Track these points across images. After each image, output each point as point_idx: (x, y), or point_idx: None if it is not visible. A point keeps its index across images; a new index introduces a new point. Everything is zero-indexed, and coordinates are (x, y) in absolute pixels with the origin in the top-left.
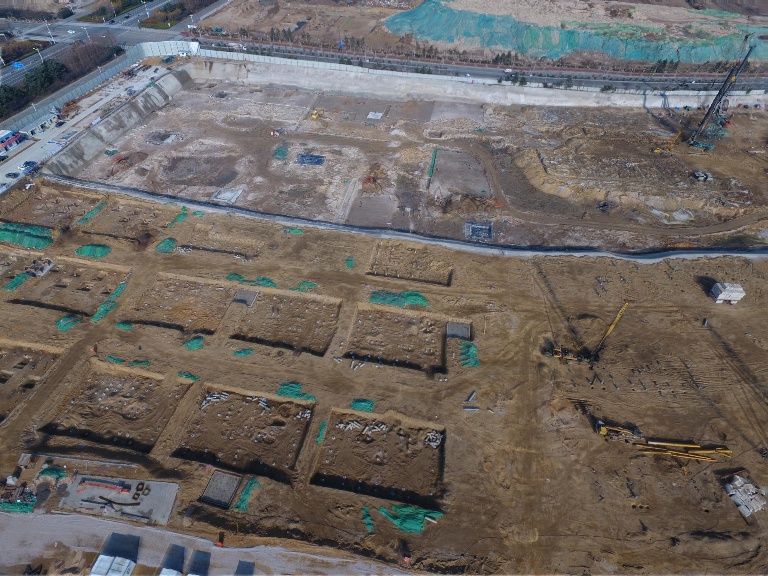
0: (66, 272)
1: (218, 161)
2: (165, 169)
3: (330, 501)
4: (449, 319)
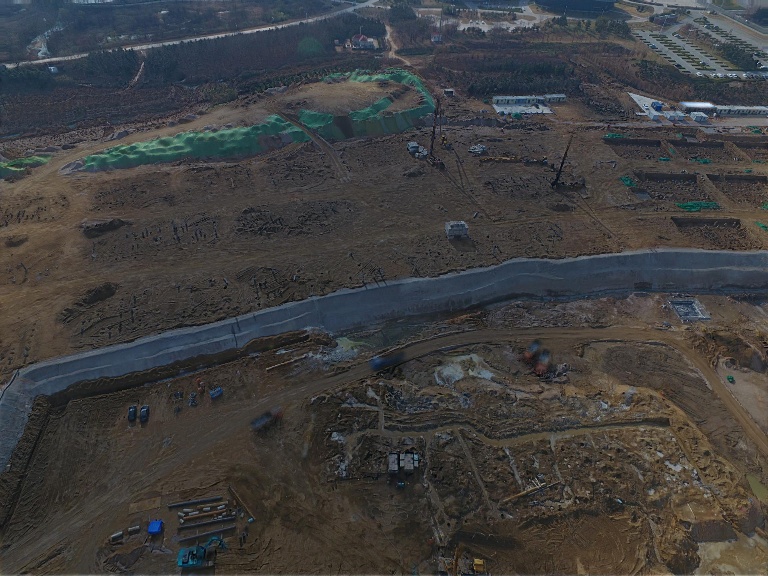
0: None
1: None
2: None
3: (647, 137)
4: None
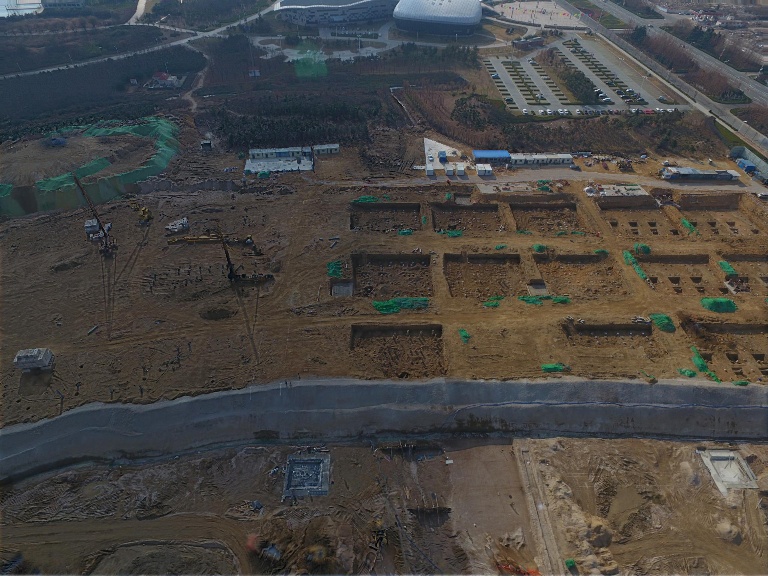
0: (712, 289)
1: None
2: None
3: (407, 200)
4: None
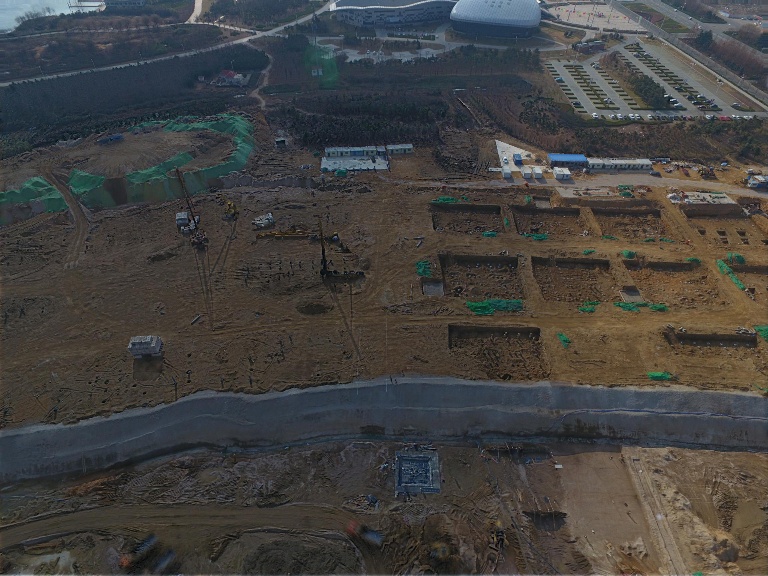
0: None
1: None
2: None
3: (486, 202)
4: None
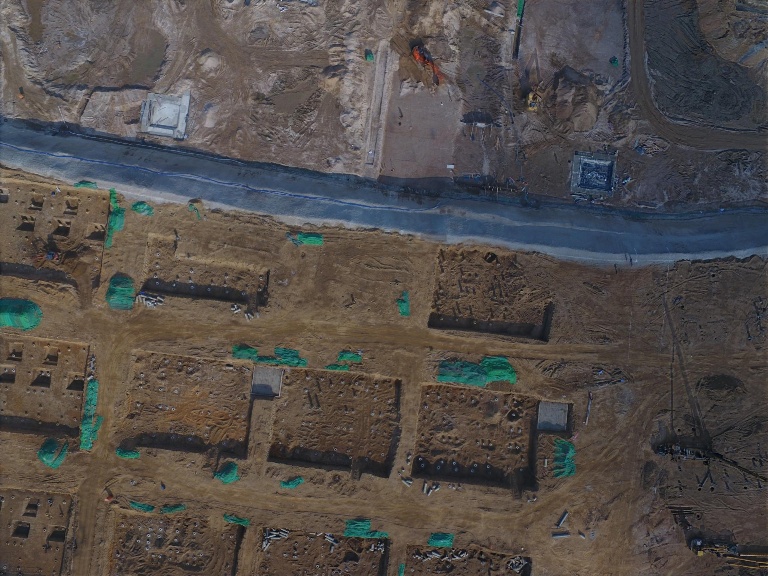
0: None
1: (116, 1)
2: (26, 39)
3: None
4: (542, 399)
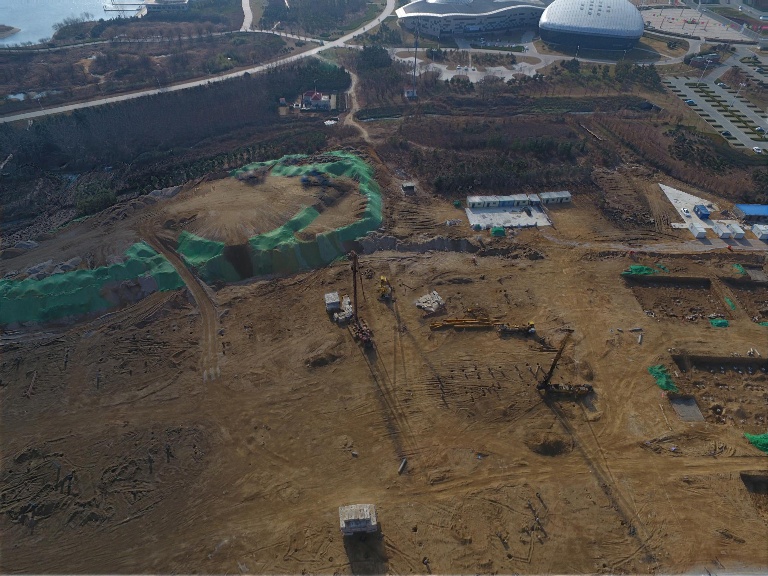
0: None
1: None
2: None
3: (690, 273)
4: None
